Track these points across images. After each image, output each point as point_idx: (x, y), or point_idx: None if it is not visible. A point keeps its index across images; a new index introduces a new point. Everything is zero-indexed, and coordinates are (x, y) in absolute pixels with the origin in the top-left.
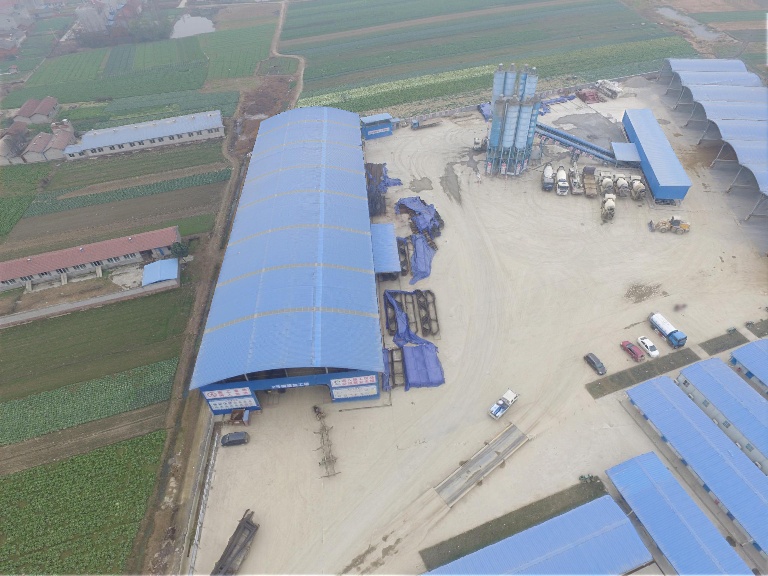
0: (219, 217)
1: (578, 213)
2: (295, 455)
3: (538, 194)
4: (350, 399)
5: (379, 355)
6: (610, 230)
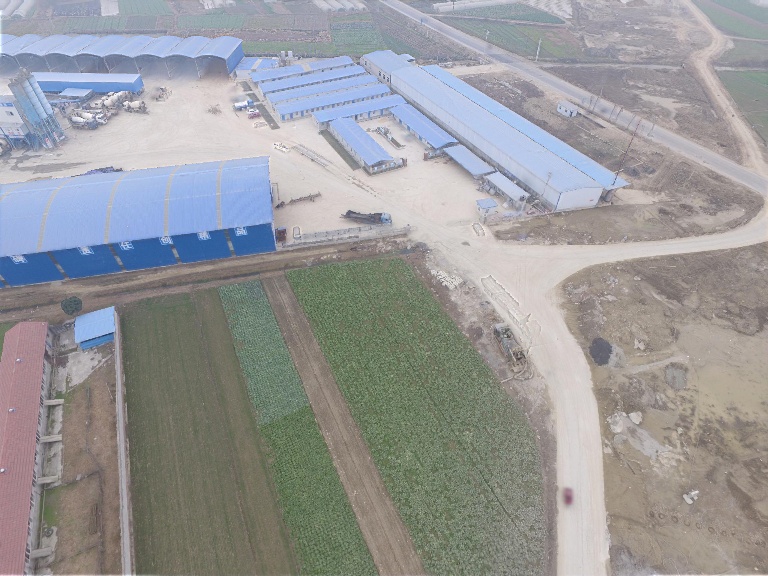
0: None
1: (131, 120)
2: (307, 212)
3: (97, 132)
4: None
5: None
6: (156, 112)
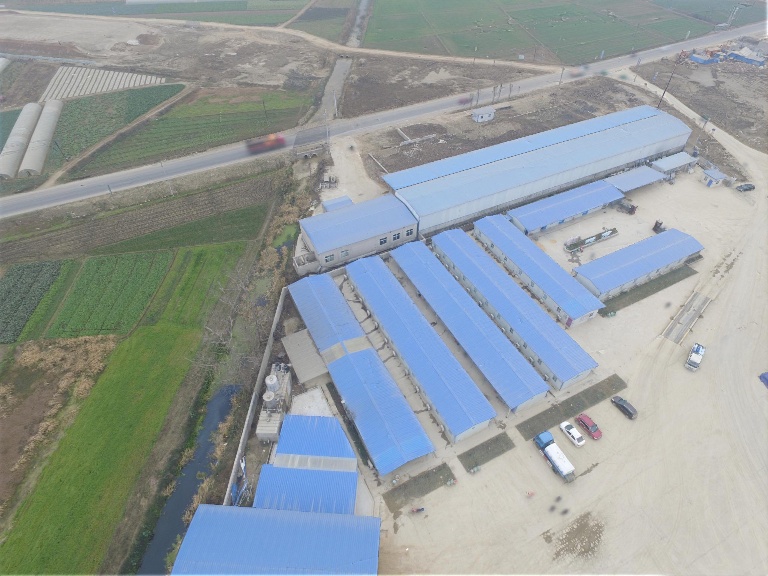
0: None
1: None
2: None
3: None
4: None
5: None
6: None
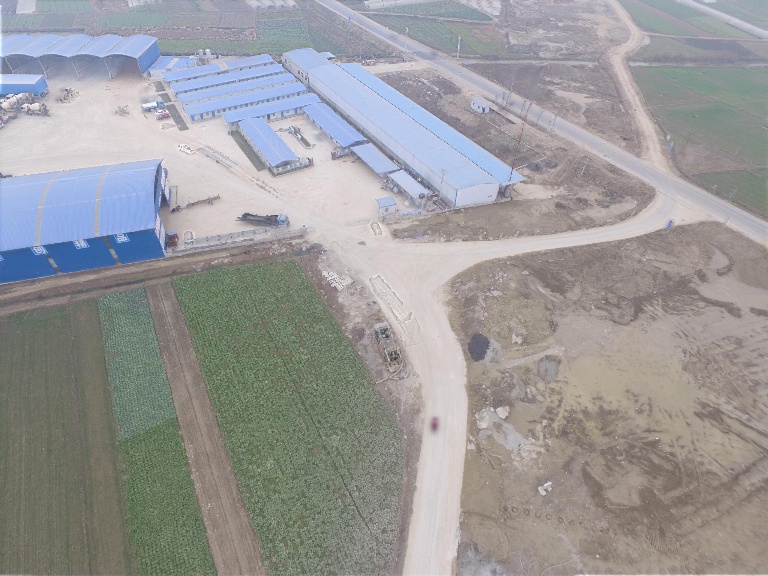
0: None
1: (30, 123)
2: (204, 215)
3: None
4: (169, 199)
5: None
6: (59, 115)
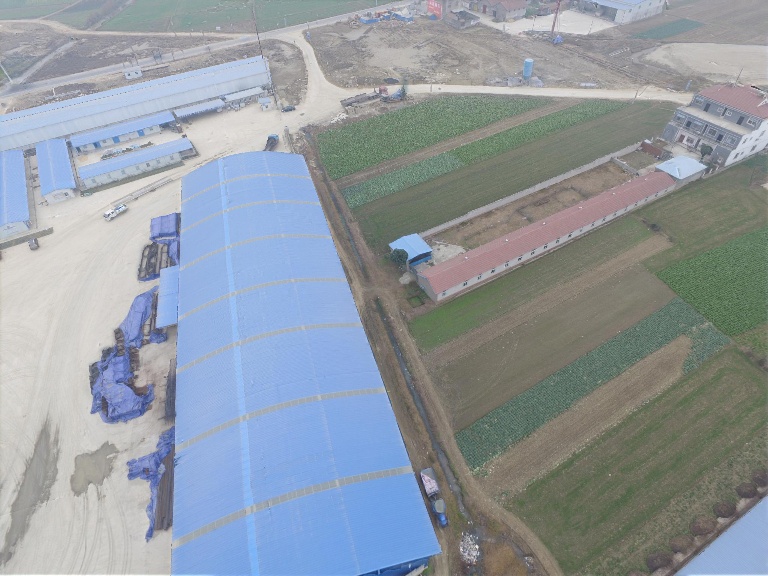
0: (412, 345)
1: None
2: None
3: None
4: None
5: (184, 182)
6: None
